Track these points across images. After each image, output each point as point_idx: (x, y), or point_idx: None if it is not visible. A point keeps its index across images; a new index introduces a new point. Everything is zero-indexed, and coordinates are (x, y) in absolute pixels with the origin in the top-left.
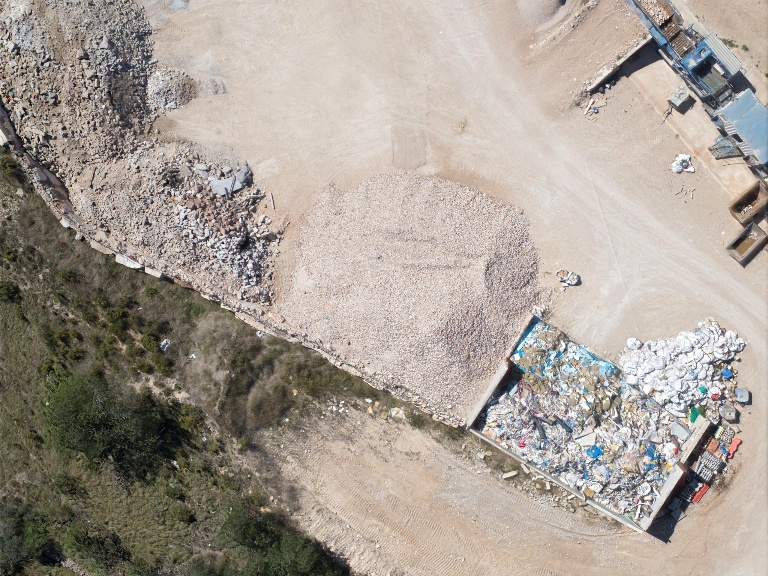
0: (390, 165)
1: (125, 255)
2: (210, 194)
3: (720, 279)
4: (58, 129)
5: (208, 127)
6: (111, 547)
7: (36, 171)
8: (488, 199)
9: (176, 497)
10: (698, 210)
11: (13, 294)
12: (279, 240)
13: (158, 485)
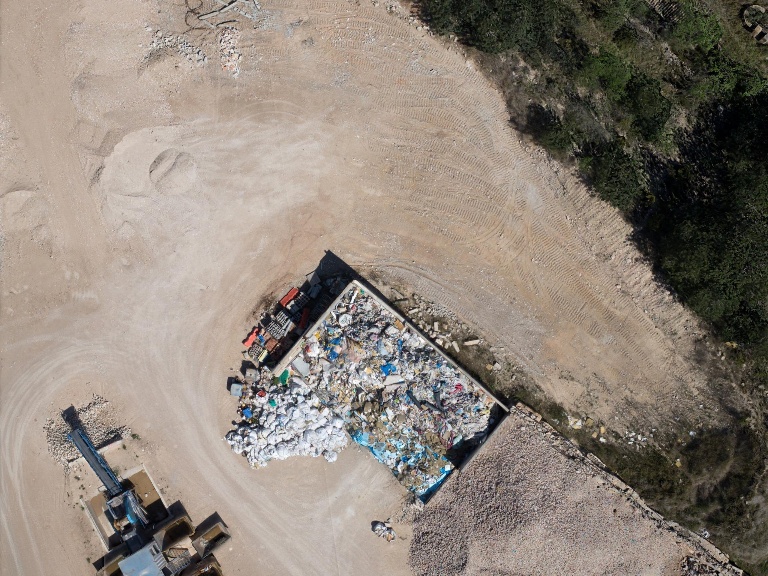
0: None
1: None
2: None
3: (240, 505)
4: None
5: None
6: None
7: None
8: None
9: None
10: (251, 575)
11: None
12: None
13: None
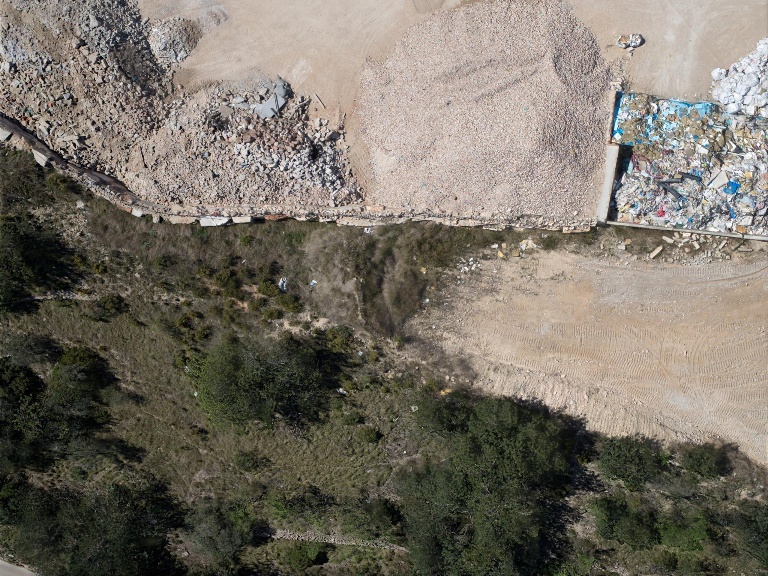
0: (415, 14)
1: (209, 215)
2: (260, 121)
3: None
4: (88, 126)
5: (226, 60)
6: (313, 500)
7: (87, 176)
8: (522, 2)
9: (356, 421)
10: None
11: (119, 304)
12: (343, 135)
13: (333, 420)
